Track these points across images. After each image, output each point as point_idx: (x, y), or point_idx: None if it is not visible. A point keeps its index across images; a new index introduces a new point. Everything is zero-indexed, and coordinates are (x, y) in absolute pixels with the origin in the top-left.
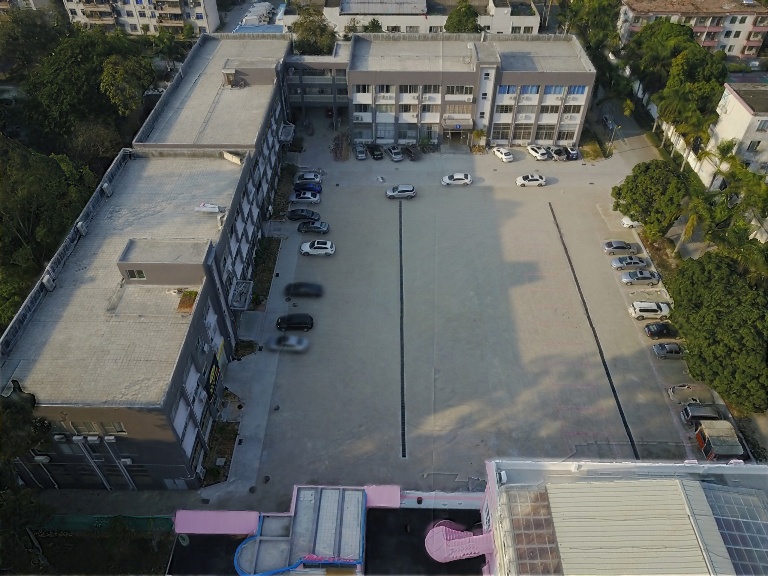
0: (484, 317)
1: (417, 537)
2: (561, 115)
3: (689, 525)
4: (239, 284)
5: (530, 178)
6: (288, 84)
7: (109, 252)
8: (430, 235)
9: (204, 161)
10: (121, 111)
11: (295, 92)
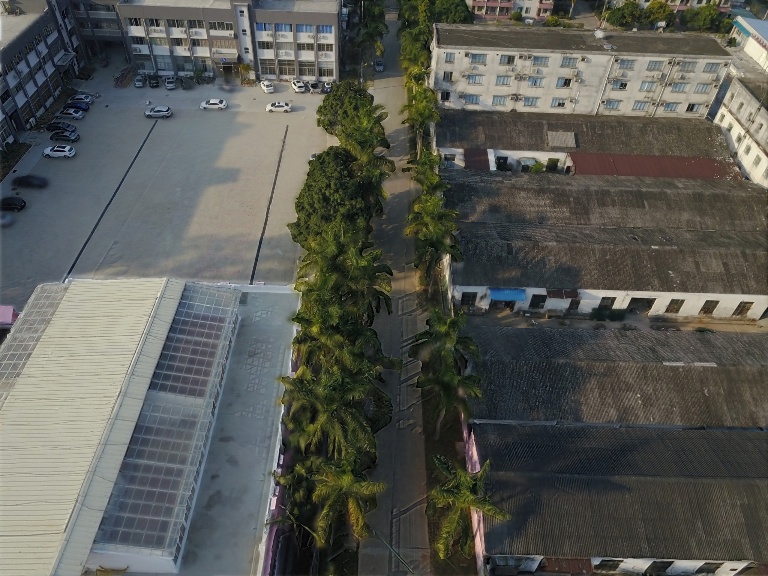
0: (178, 206)
1: None
2: (316, 53)
3: (153, 303)
4: None
5: (277, 105)
6: (76, 18)
7: None
8: (168, 146)
9: None
10: None
11: (87, 26)
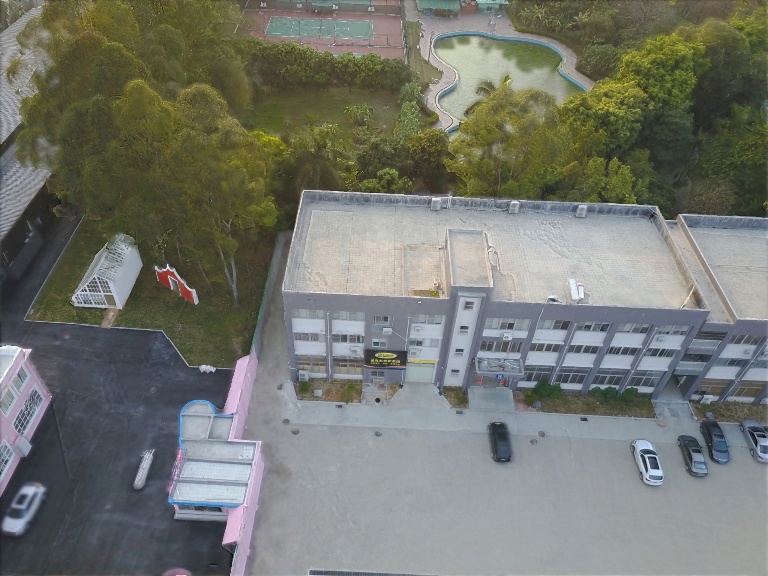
0: None
1: (202, 575)
2: None
3: None
4: (517, 362)
5: None
6: None
7: (489, 232)
8: None
9: (676, 277)
10: (767, 203)
11: None
